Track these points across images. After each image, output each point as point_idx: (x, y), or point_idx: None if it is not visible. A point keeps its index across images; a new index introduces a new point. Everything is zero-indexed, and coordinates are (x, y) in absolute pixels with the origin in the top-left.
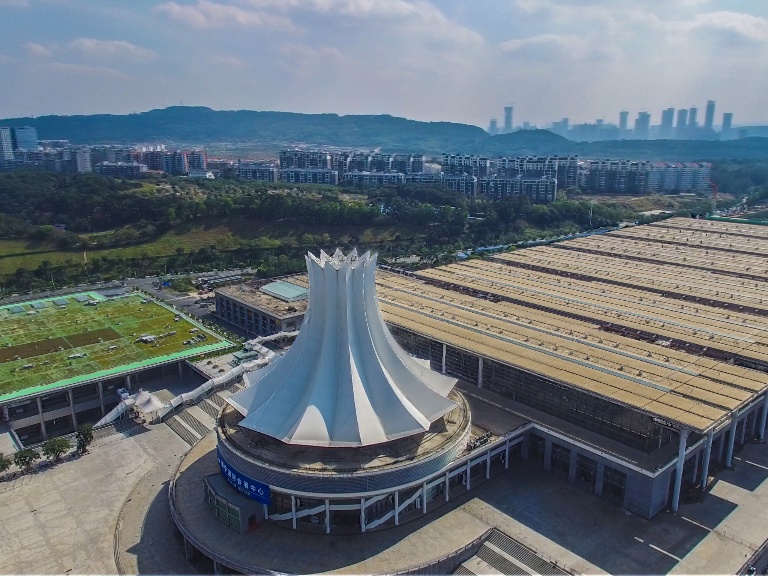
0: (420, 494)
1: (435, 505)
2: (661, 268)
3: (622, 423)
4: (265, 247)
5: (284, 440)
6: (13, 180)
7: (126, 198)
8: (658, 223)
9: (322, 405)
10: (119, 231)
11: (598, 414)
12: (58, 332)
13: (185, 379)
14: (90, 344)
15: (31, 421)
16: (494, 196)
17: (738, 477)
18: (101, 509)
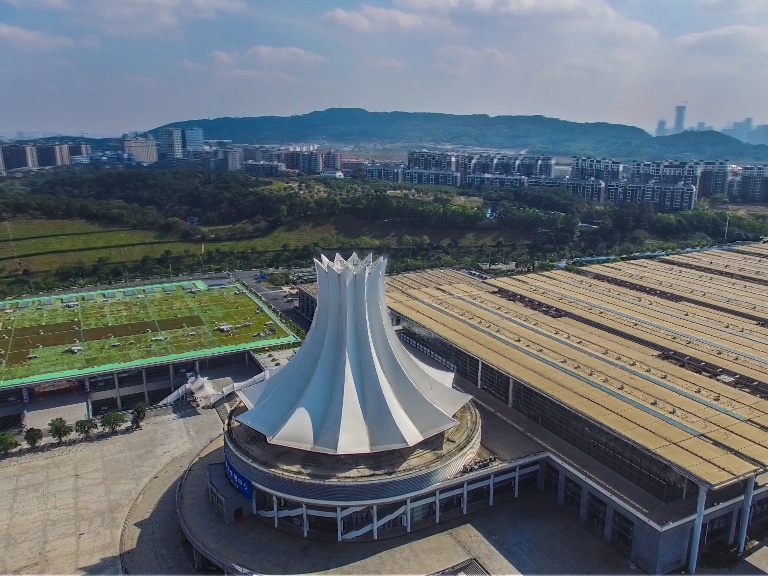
0: (404, 511)
1: (423, 525)
2: None
3: (641, 465)
4: (365, 247)
5: (268, 439)
6: (166, 176)
7: (251, 195)
8: None
9: (313, 408)
10: (235, 225)
11: (618, 451)
12: (153, 316)
13: (250, 369)
14: (175, 329)
15: (109, 394)
16: (622, 203)
17: None
18: (130, 482)
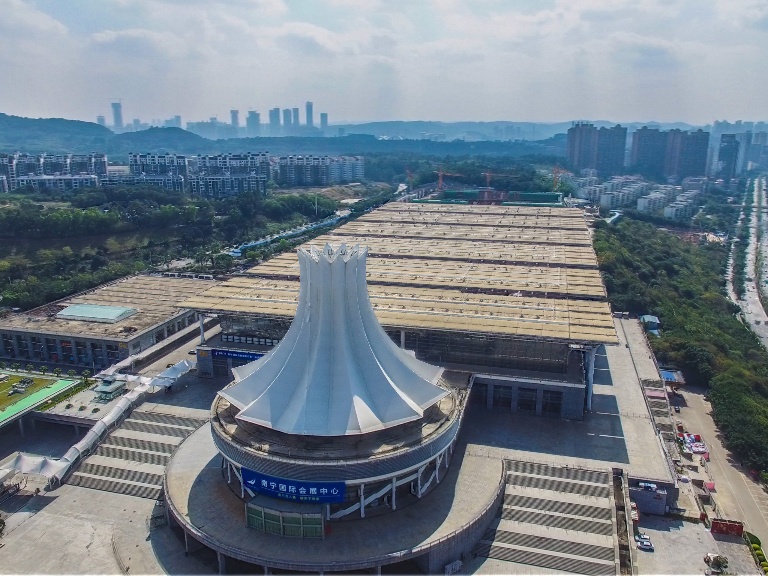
0: (444, 451)
1: (447, 459)
2: (440, 242)
3: (543, 356)
4: None
5: (351, 433)
6: None
7: None
8: (384, 208)
9: (360, 394)
10: None
11: (522, 354)
12: None
13: (29, 435)
14: None
15: None
16: (206, 194)
17: (597, 379)
18: None
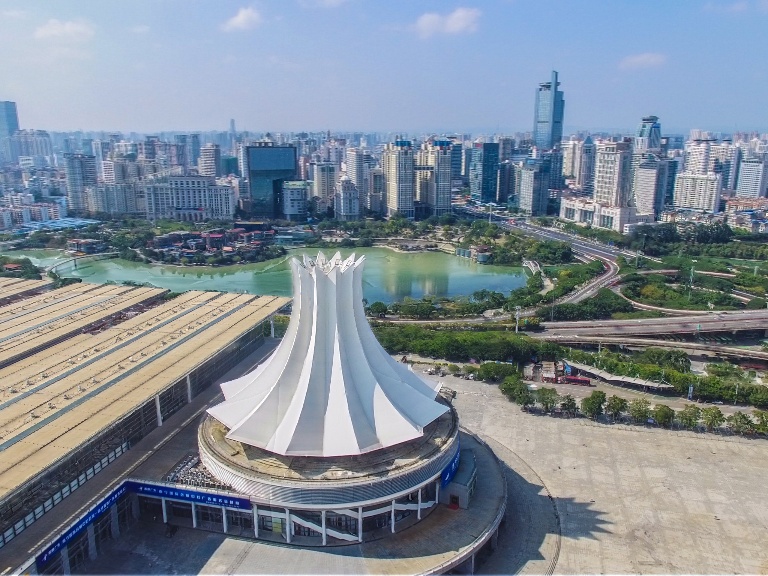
0: None
1: None
2: None
3: None
4: None
5: None
6: None
7: None
8: None
9: None
10: None
11: None
12: None
13: None
14: None
15: None
16: None
17: None
18: None
